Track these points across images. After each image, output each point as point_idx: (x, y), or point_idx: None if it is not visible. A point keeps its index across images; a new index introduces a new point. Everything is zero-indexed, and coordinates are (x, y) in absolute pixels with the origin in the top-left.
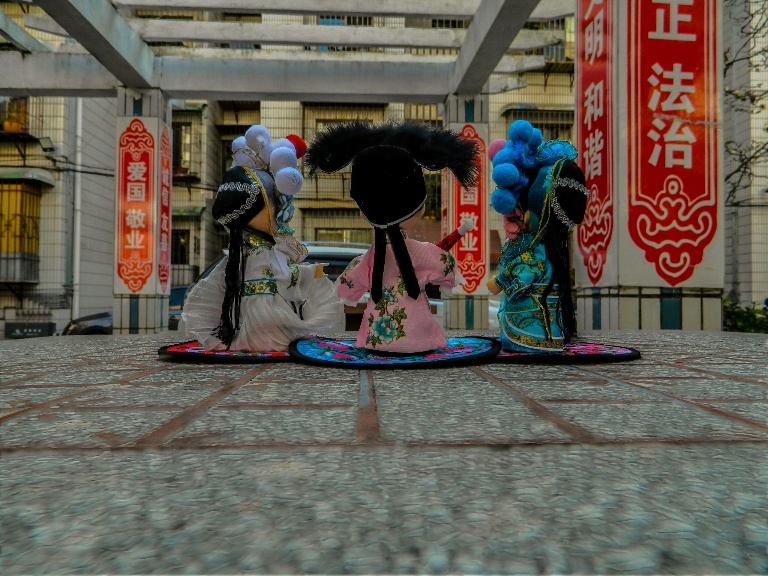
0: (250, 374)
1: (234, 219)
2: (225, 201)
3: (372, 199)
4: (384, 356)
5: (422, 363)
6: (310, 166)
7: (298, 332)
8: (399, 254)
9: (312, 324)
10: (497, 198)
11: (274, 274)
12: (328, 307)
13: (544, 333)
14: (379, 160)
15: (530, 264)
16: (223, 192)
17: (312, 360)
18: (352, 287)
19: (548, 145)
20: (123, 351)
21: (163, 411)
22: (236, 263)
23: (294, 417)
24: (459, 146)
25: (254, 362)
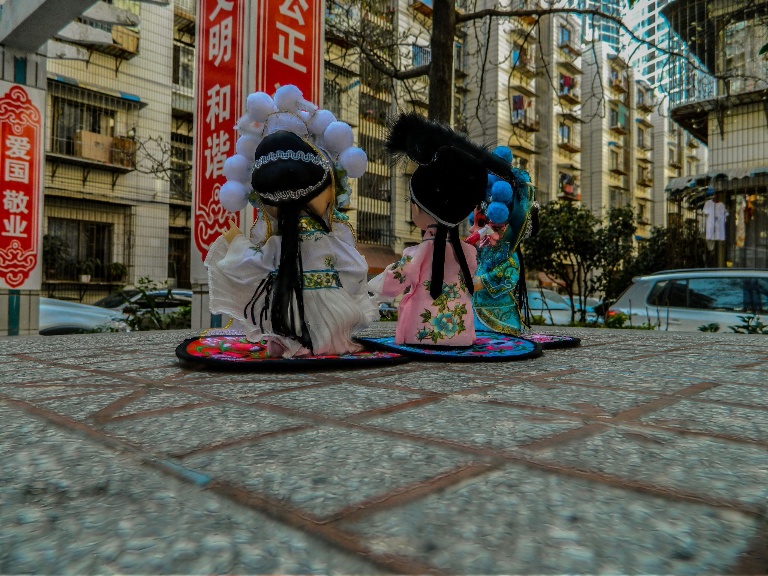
0: (481, 373)
1: (302, 196)
2: (300, 173)
3: (456, 198)
4: (445, 350)
5: (537, 352)
6: (396, 153)
7: (356, 330)
8: (458, 253)
9: (369, 321)
10: (500, 210)
11: (338, 265)
12: (369, 303)
13: (518, 324)
14: (463, 161)
15: (516, 268)
16: (293, 161)
17: (453, 357)
18: (403, 282)
19: (518, 171)
20: (5, 373)
21: (678, 403)
22: (295, 249)
23: (744, 392)
24: (506, 162)
25: (393, 364)
